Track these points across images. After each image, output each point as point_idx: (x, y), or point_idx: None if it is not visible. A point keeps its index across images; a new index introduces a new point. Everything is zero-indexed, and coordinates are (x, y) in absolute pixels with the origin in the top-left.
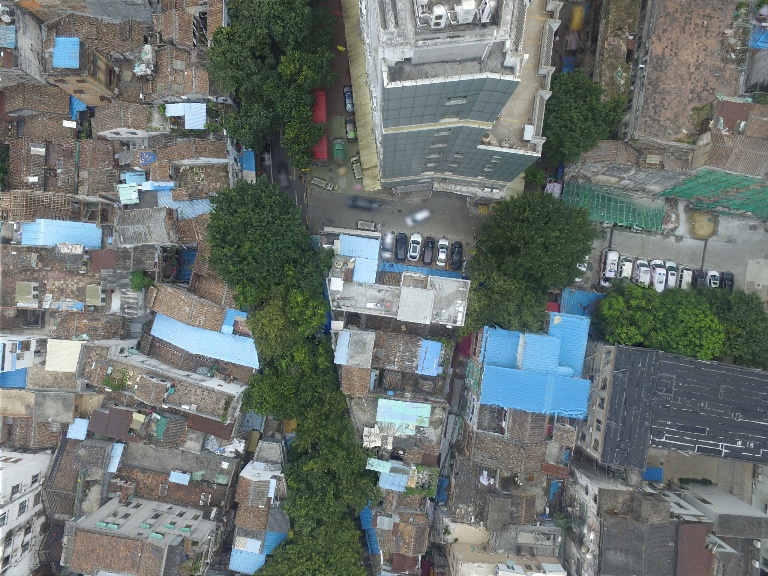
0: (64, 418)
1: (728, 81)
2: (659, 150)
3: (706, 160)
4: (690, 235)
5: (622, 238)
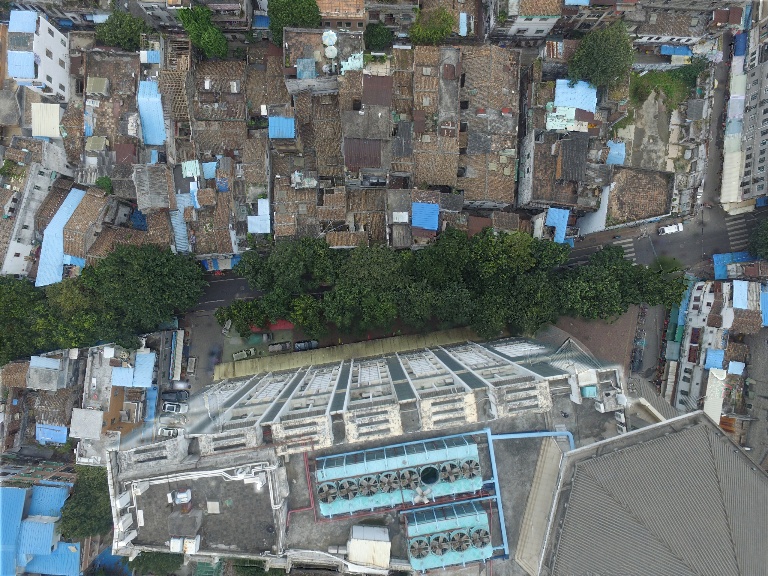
0: None
1: None
2: None
3: None
4: None
5: None
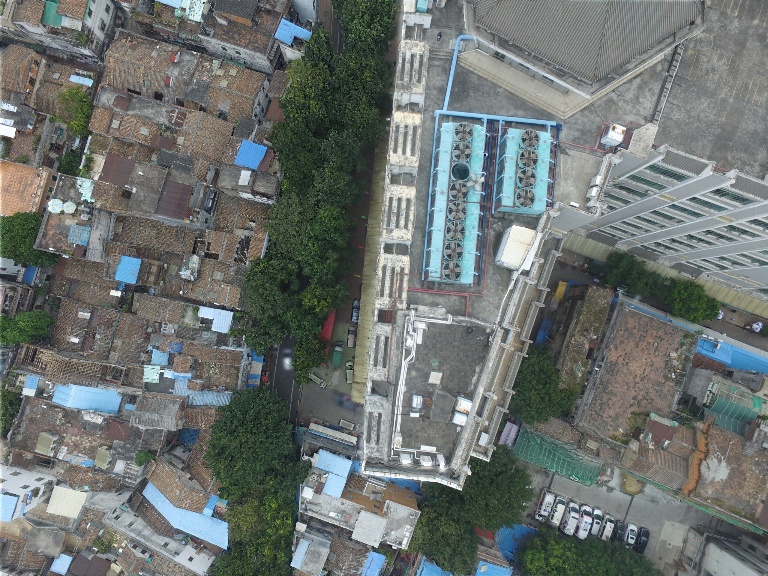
0: (51, 552)
1: (665, 395)
2: (598, 439)
3: (631, 466)
4: (620, 489)
5: (562, 480)
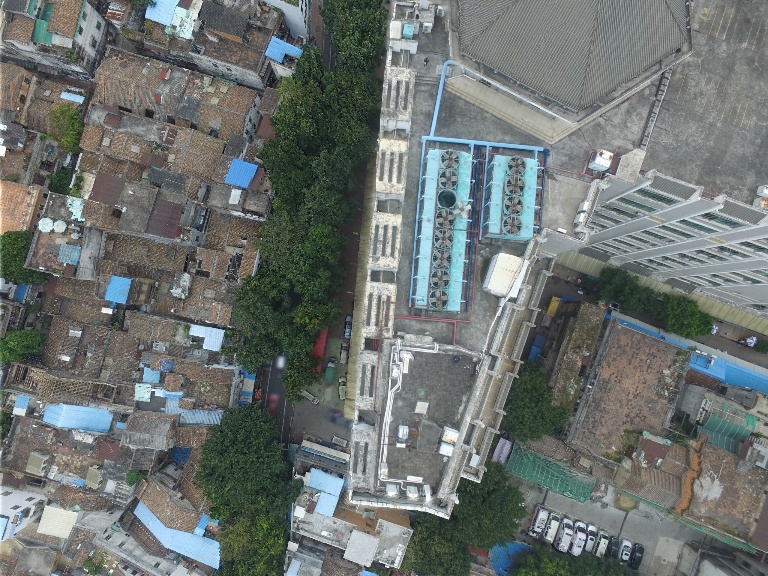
0: (43, 572)
1: (658, 413)
2: (591, 456)
3: (624, 484)
4: (615, 504)
5: (556, 496)
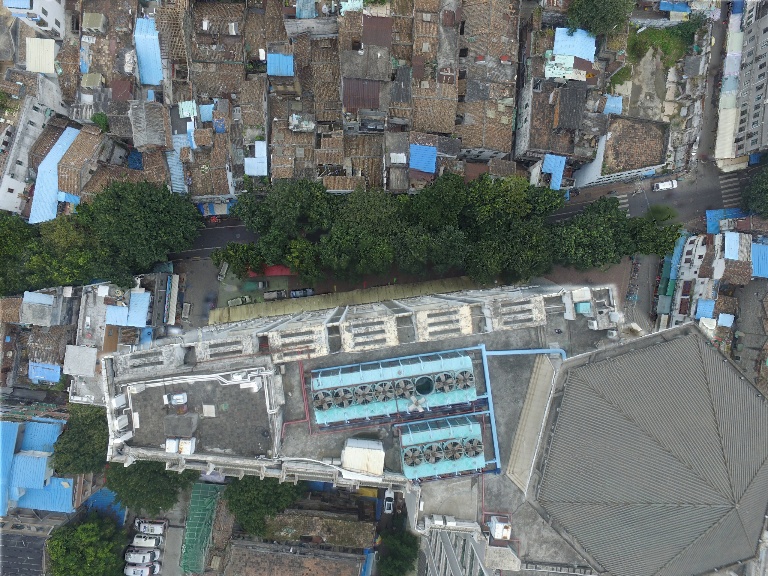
0: None
1: None
2: (223, 567)
3: None
4: None
5: (180, 536)
